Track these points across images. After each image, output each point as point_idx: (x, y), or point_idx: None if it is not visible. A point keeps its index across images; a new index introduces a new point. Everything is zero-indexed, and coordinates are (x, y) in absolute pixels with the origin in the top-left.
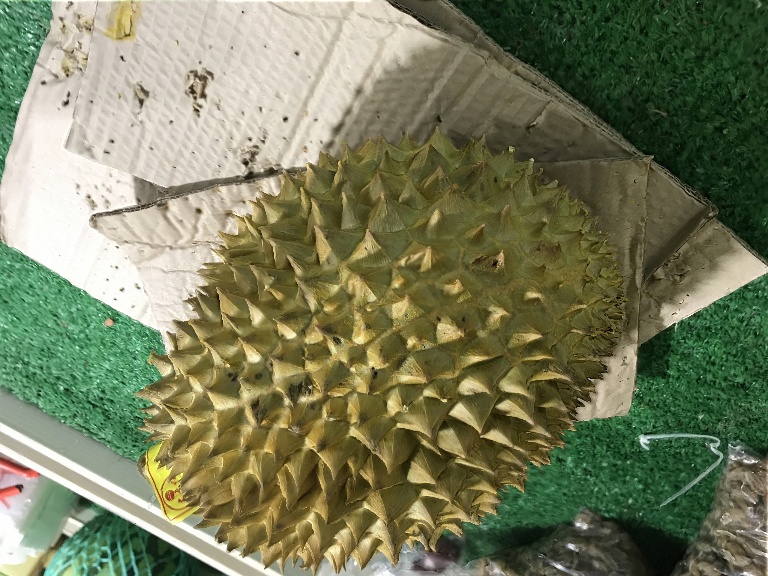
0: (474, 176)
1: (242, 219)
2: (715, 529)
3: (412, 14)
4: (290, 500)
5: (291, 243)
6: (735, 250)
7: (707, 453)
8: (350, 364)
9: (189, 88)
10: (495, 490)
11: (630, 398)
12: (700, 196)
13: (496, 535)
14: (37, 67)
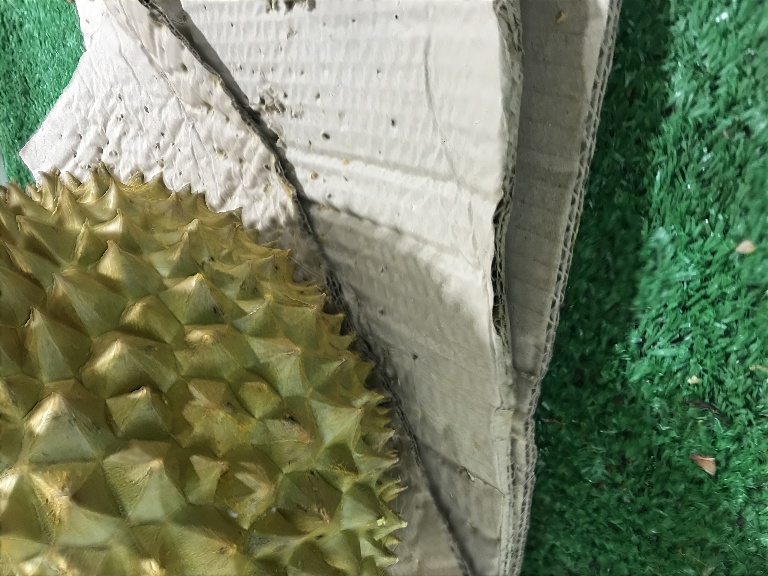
0: (303, 513)
1: (117, 196)
2: None
3: (498, 295)
4: None
5: (50, 341)
6: None
7: None
8: None
9: None
10: None
11: None
12: None
13: None
14: None
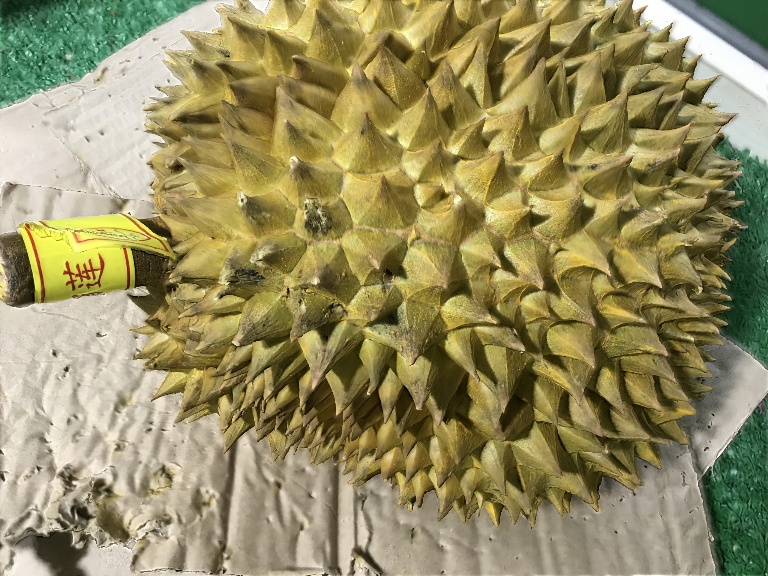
0: None
1: None
2: None
3: None
4: None
5: None
6: (737, 353)
7: None
8: None
9: None
10: None
11: (709, 551)
12: None
13: None
14: (40, 94)
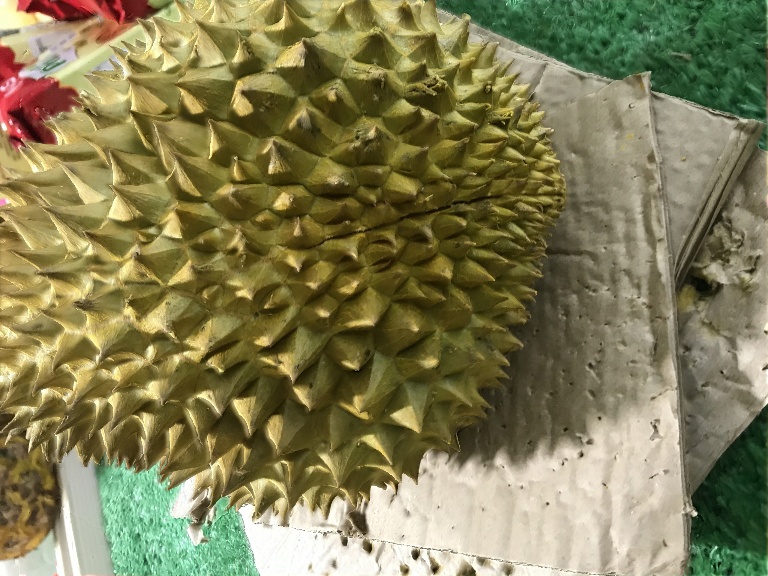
0: None
1: None
2: None
3: None
4: (16, 207)
5: None
6: None
7: None
8: None
9: None
10: (178, 207)
11: (680, 531)
12: (735, 115)
13: None
14: None
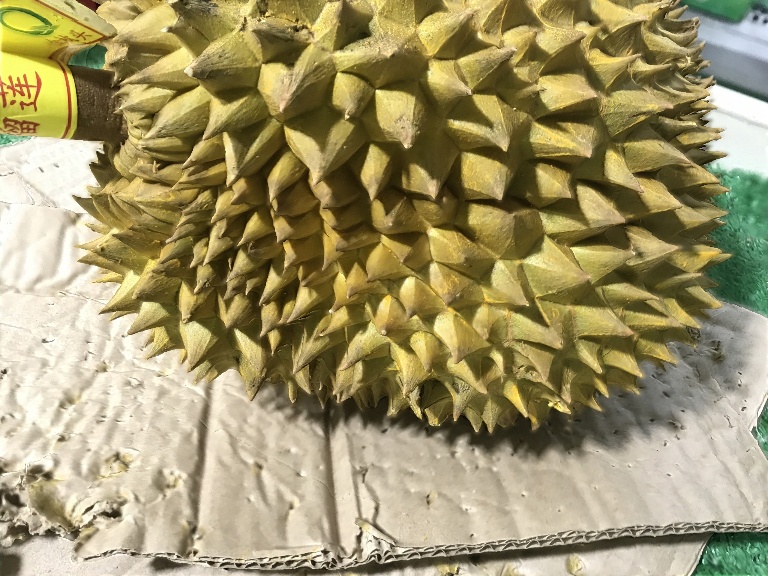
0: None
1: None
2: None
3: None
4: None
5: None
6: (746, 314)
7: None
8: None
9: None
10: None
11: None
12: None
13: None
14: None
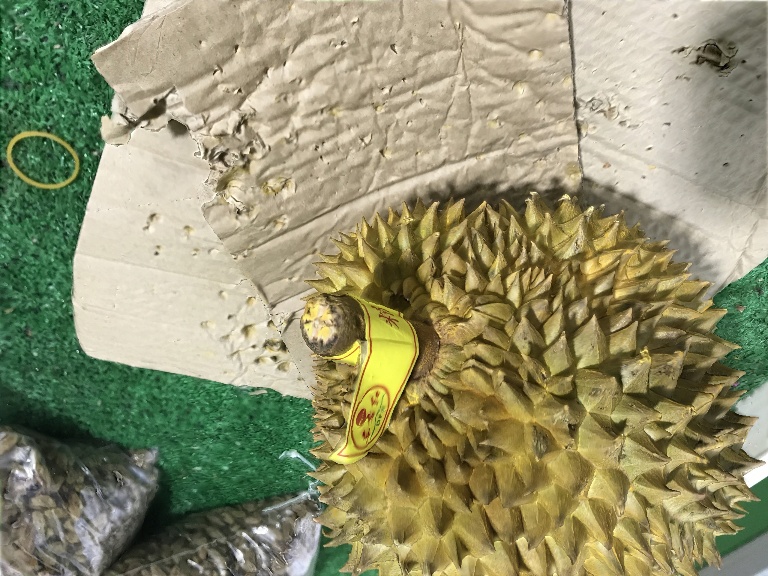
0: None
1: None
2: (242, 530)
3: None
4: None
5: None
6: None
7: (297, 482)
8: (718, 554)
9: (715, 44)
10: None
11: None
12: None
13: (30, 407)
14: None
